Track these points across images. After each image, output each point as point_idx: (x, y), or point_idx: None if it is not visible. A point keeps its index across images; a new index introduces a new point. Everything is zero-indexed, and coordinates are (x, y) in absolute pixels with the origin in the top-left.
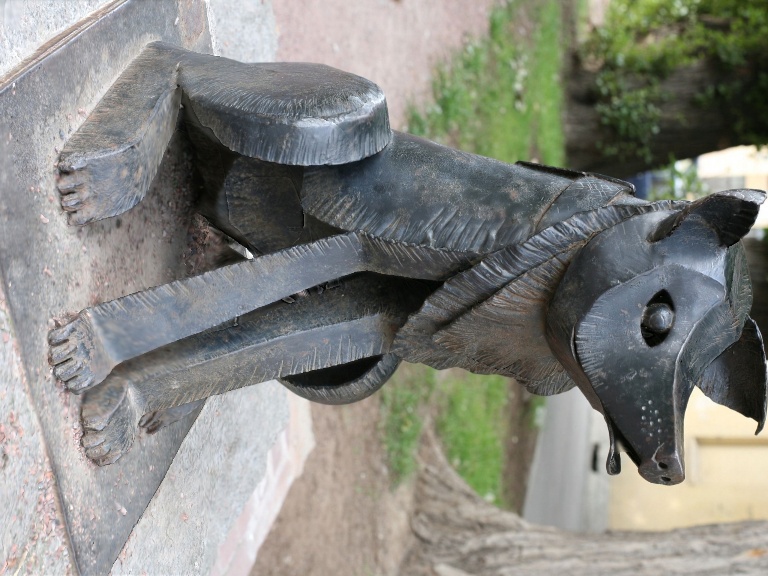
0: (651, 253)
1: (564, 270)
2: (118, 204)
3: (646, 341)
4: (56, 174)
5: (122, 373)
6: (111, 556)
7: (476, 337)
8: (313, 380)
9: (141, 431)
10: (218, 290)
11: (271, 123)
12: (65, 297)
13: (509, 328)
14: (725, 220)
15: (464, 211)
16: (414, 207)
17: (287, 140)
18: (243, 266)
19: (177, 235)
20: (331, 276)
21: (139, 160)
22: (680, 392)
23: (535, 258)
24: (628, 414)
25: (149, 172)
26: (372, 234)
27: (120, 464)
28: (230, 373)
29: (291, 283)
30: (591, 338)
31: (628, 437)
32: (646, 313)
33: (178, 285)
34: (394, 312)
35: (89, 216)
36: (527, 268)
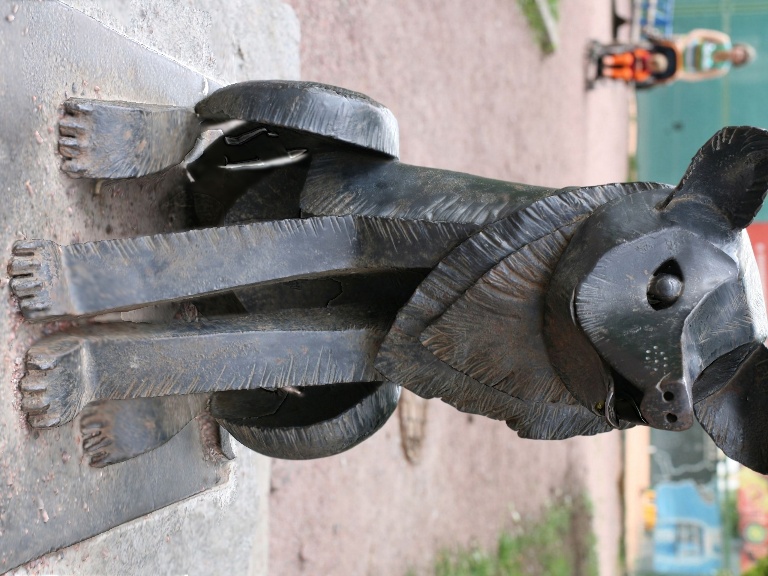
0: (659, 218)
1: (567, 245)
2: (115, 166)
3: (652, 307)
4: (60, 114)
5: (80, 335)
6: (20, 551)
7: (468, 334)
8: (283, 421)
9: (84, 458)
10: (200, 253)
11: (283, 87)
12: (40, 233)
13: (504, 320)
14: (737, 200)
15: (467, 197)
16: (415, 197)
17: (296, 103)
18: (231, 231)
19: (163, 307)
20: (320, 266)
21: (145, 131)
22: (689, 352)
23: (537, 229)
24: (630, 357)
25: (152, 157)
26: (369, 216)
27: (54, 465)
28: (196, 365)
29: (278, 263)
30: (593, 300)
31: (630, 376)
32: (653, 280)
33: (160, 239)
34: (382, 328)
35: (83, 166)
36: (528, 241)
